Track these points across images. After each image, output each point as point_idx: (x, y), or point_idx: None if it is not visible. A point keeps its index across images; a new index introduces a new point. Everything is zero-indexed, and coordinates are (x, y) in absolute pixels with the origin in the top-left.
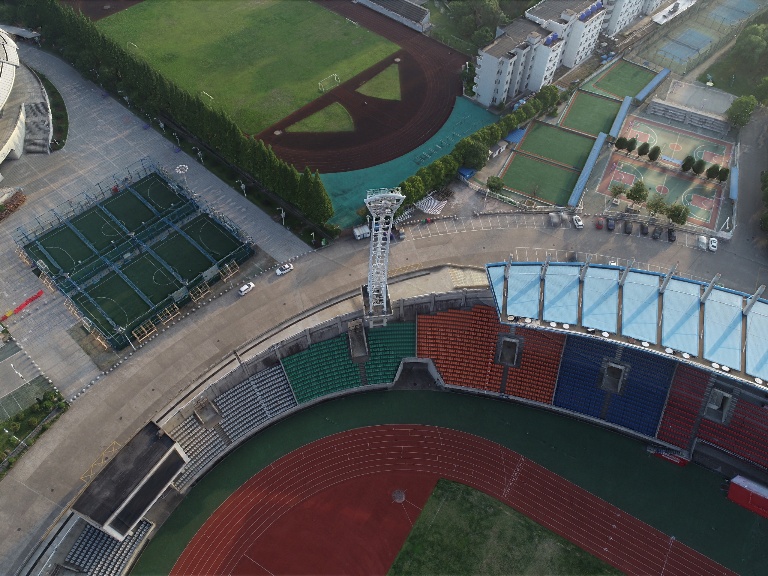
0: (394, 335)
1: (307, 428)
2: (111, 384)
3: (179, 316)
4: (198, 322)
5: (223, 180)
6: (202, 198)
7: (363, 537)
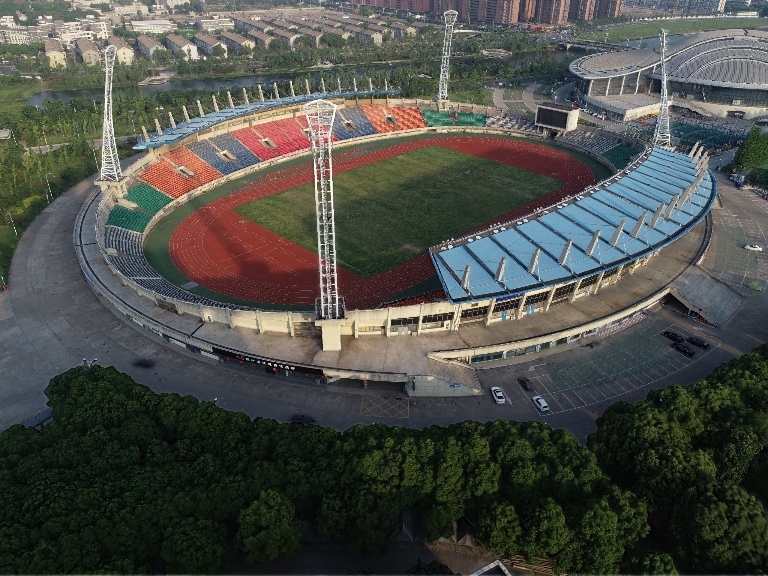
0: None
1: None
2: None
3: None
4: None
5: None
6: None
7: None
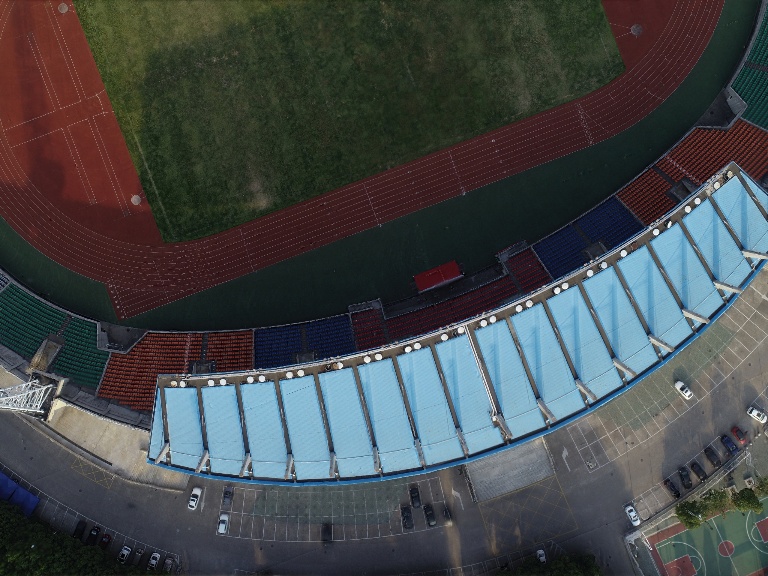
0: None
1: (741, 1)
2: None
3: None
4: None
5: None
6: None
7: None
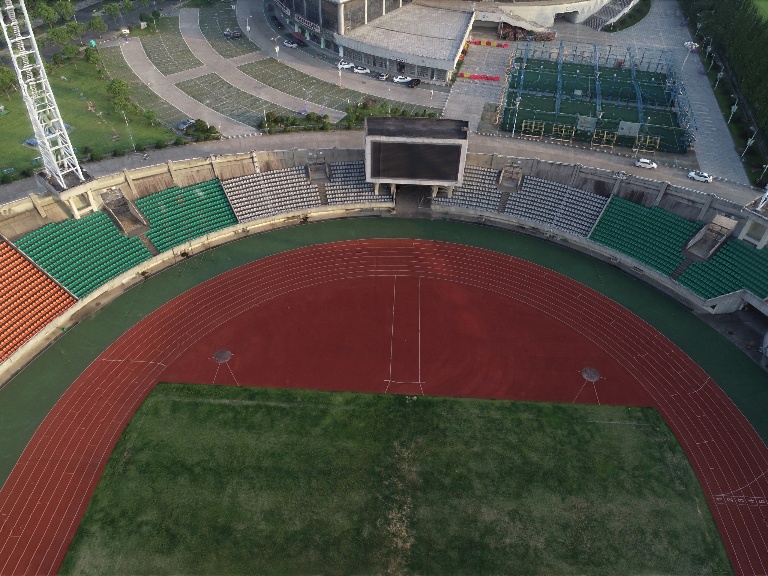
0: (760, 263)
1: (573, 266)
2: (473, 140)
3: (568, 143)
4: (578, 155)
5: (720, 105)
6: (684, 104)
7: (517, 360)
